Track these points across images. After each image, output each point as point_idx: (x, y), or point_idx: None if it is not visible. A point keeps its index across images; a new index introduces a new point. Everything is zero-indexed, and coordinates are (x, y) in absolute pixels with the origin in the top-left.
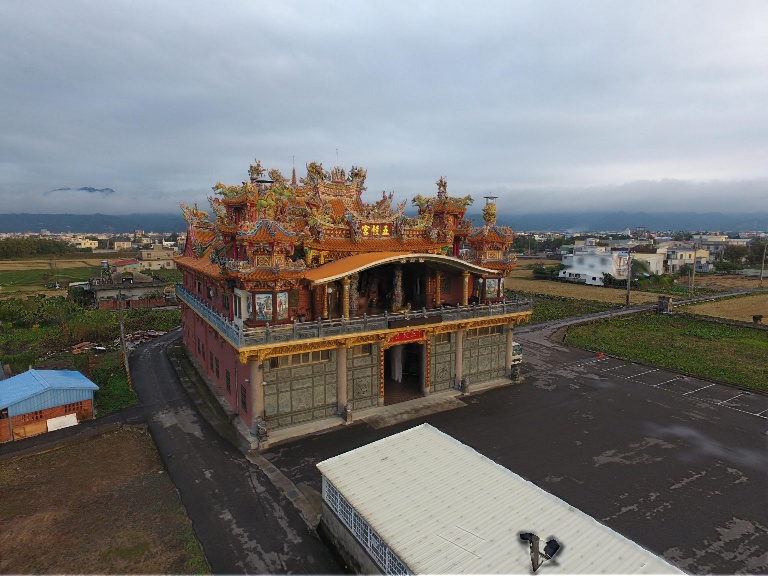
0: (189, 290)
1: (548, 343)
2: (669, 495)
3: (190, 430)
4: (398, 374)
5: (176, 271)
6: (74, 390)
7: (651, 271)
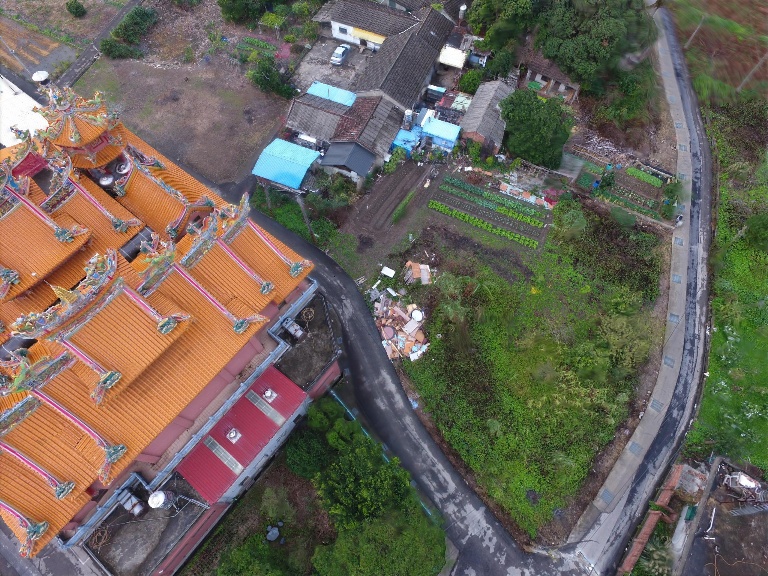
0: None
1: None
2: None
3: None
4: None
5: None
6: None
7: None
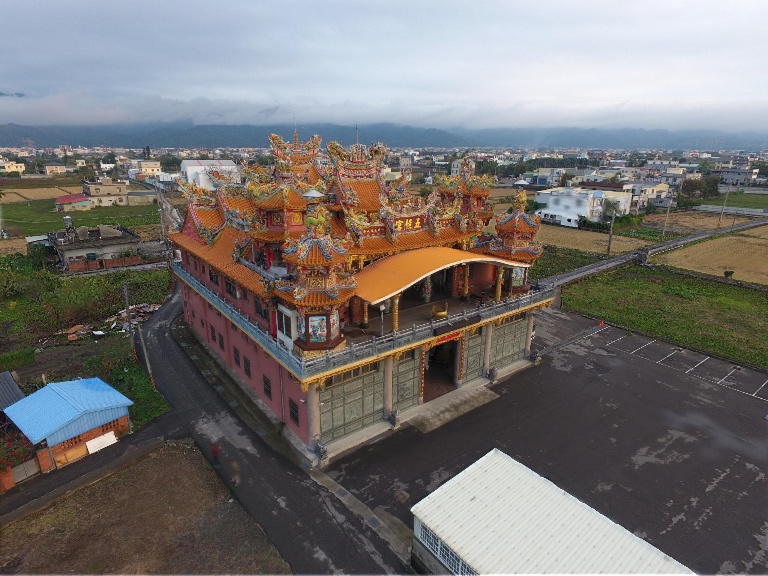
0: (198, 277)
1: (549, 309)
2: (707, 500)
3: (241, 445)
4: (425, 362)
5: (131, 208)
6: (109, 409)
7: (620, 210)
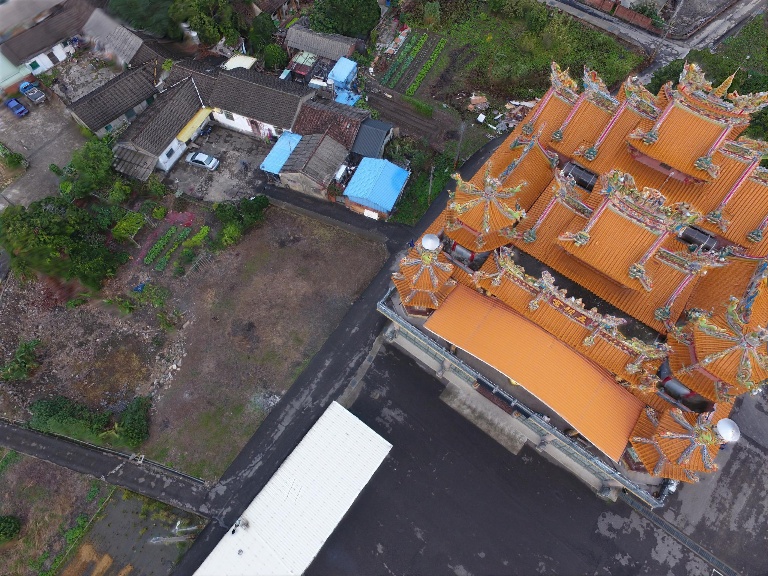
0: None
1: None
2: None
3: None
4: None
5: None
6: (378, 205)
7: None
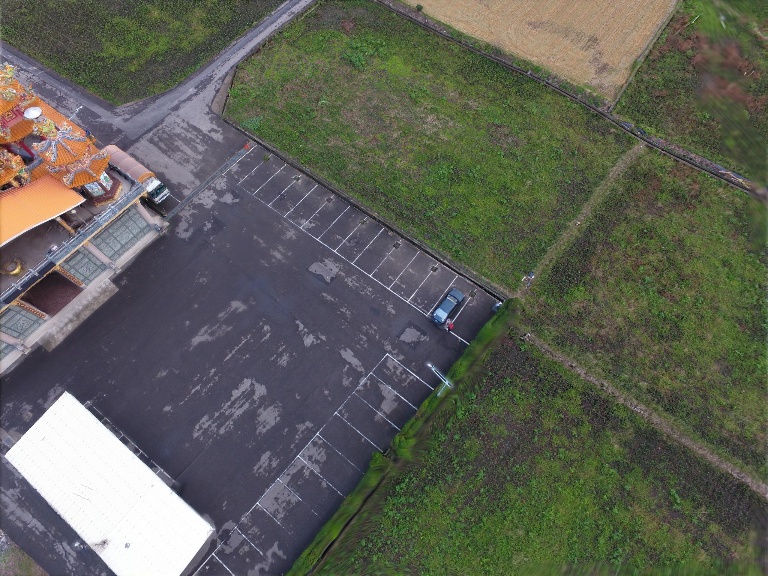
0: None
1: (206, 124)
2: (221, 368)
3: None
4: None
5: None
6: None
7: None
